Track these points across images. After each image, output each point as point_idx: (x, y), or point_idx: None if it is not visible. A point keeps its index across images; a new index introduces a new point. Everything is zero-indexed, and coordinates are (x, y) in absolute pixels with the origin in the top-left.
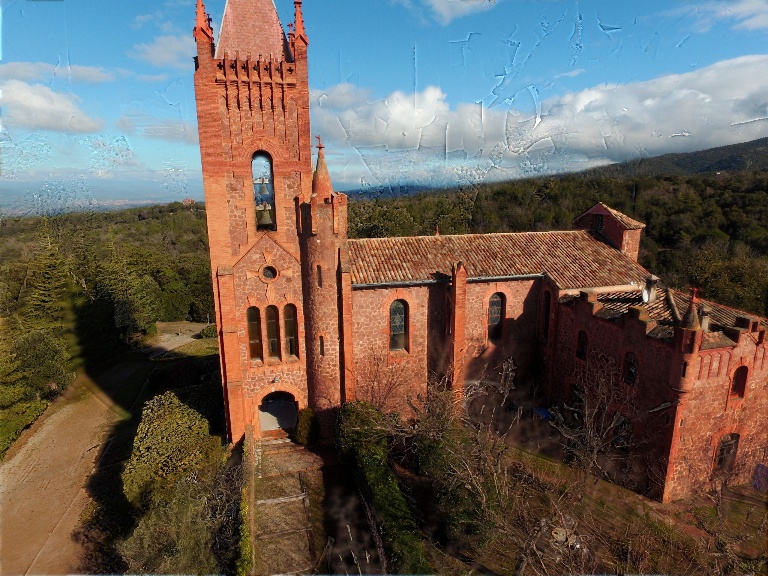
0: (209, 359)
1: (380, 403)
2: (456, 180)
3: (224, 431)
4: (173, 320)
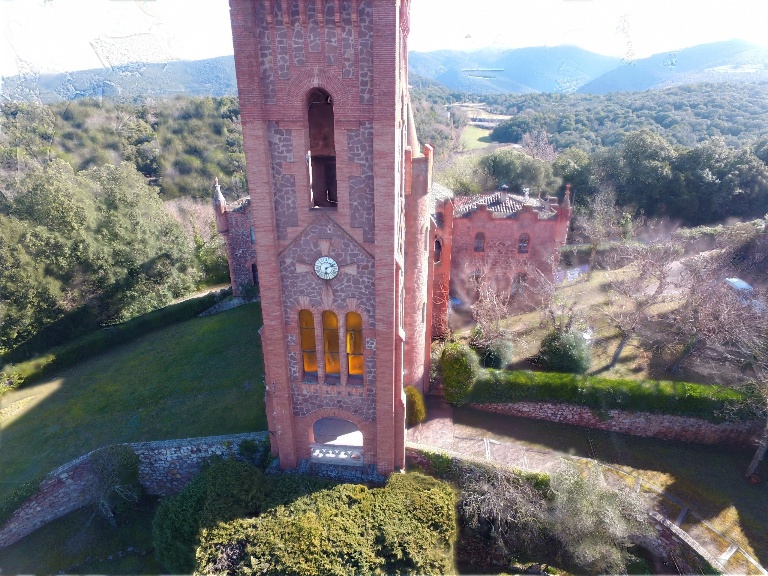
0: None
1: None
2: None
3: None
4: None
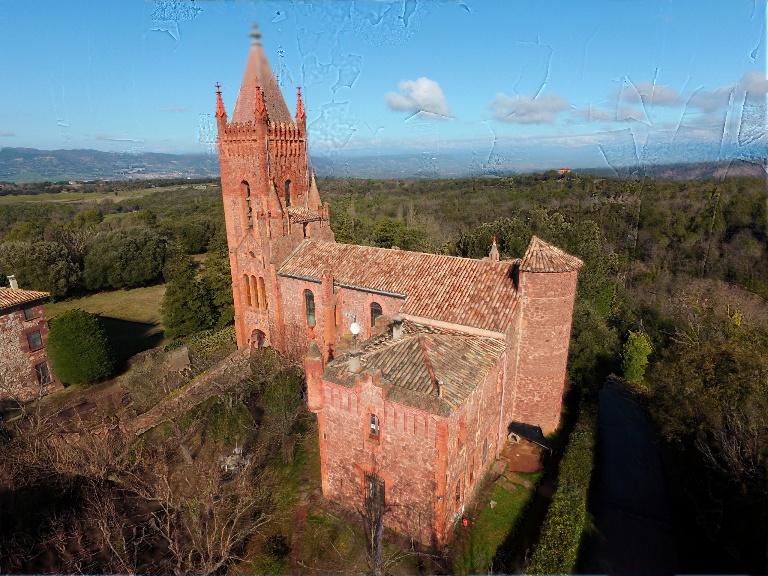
0: None
1: (302, 359)
2: None
3: None
4: None
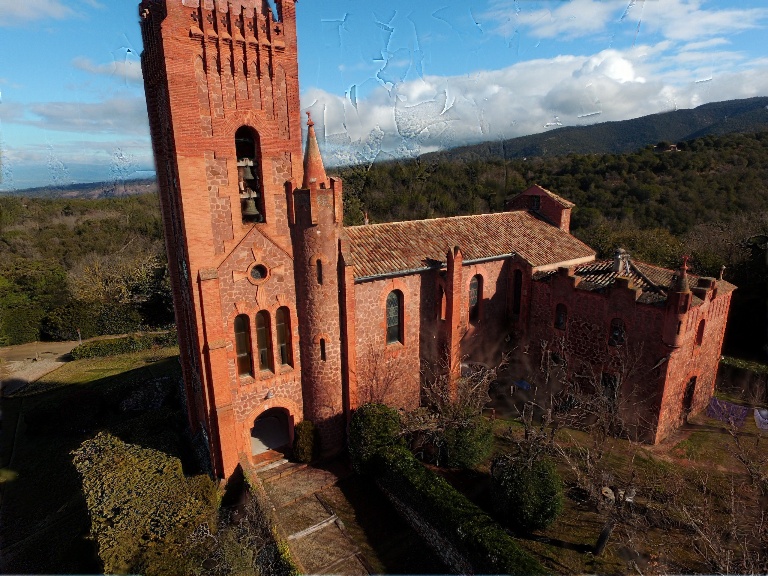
0: (102, 384)
1: (378, 401)
2: (336, 165)
3: (198, 467)
4: (18, 343)
